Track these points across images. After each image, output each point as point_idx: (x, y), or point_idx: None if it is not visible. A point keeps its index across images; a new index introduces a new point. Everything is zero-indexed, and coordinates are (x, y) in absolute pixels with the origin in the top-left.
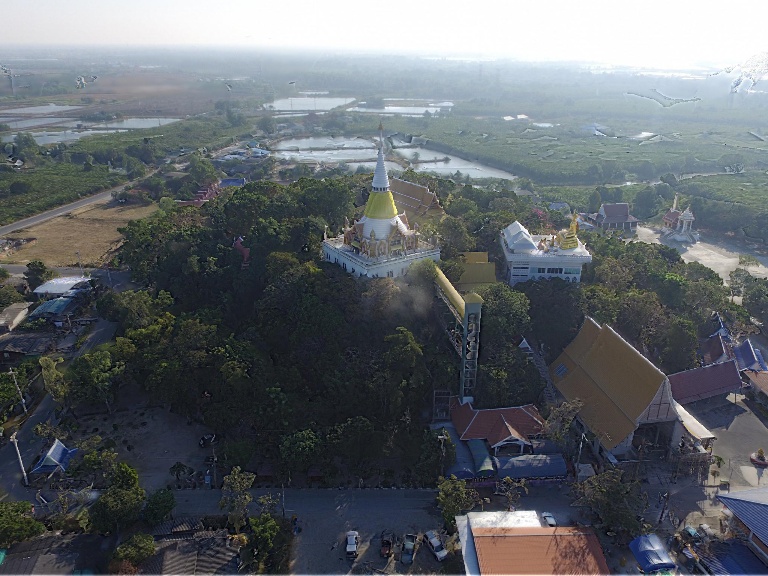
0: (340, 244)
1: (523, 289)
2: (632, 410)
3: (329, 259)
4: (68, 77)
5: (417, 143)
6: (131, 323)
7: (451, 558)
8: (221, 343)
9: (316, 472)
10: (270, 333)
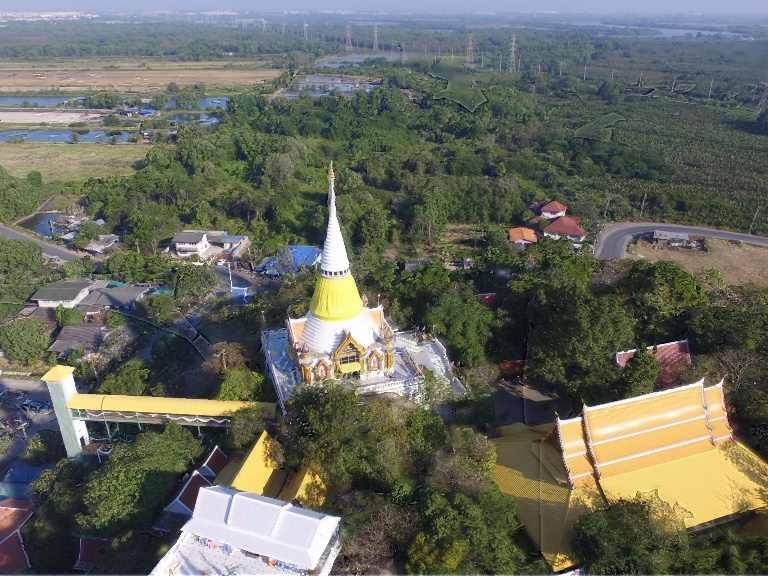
0: None
1: None
2: None
3: None
4: None
5: None
6: None
7: None
8: None
9: None
10: None
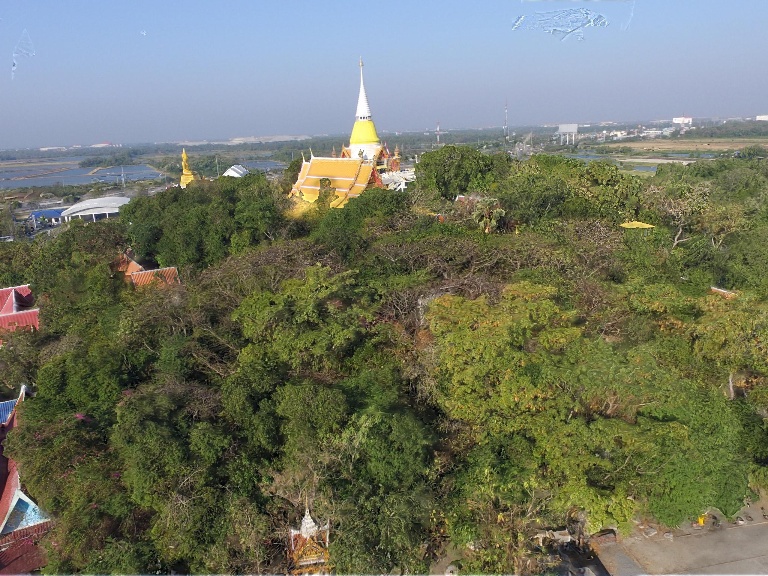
0: None
1: None
2: None
3: None
4: None
5: None
6: None
7: None
8: None
9: None
10: None
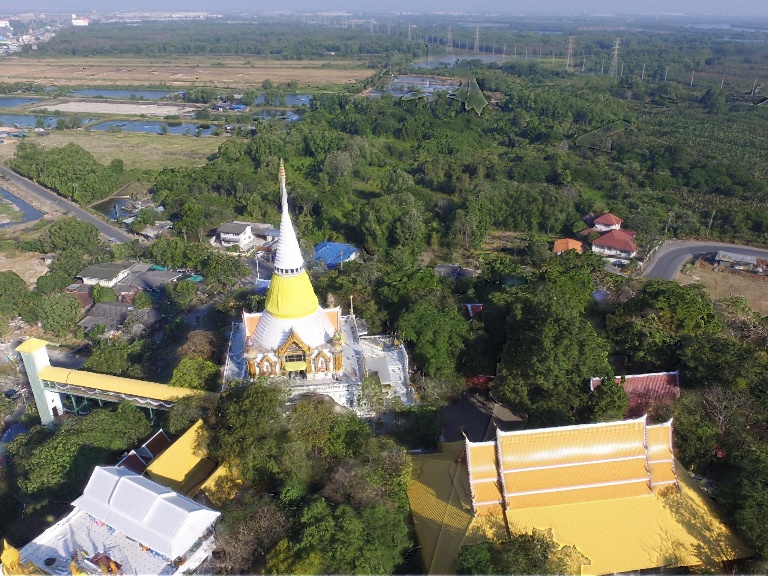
0: (344, 330)
1: None
2: None
3: None
4: None
5: None
6: None
7: None
8: None
9: None
10: None
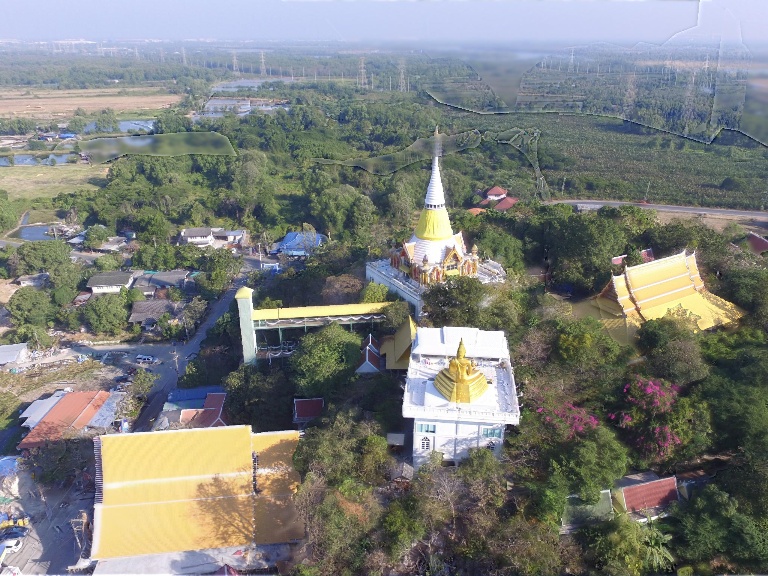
0: None
1: None
2: None
3: None
4: None
5: None
6: None
7: None
8: None
9: None
10: None
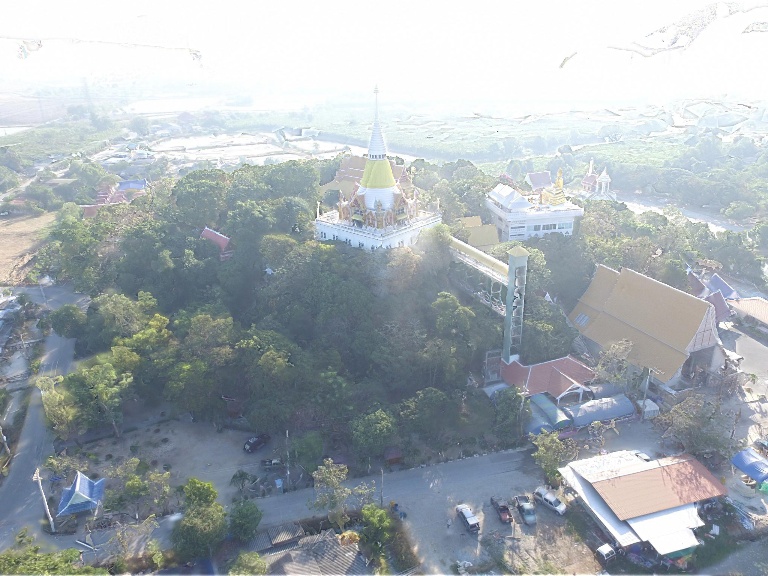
0: (334, 221)
1: (529, 246)
2: (678, 342)
3: (325, 238)
4: (7, 44)
5: (309, 135)
6: (115, 331)
7: (570, 510)
8: (242, 336)
9: (394, 454)
10: (292, 319)
